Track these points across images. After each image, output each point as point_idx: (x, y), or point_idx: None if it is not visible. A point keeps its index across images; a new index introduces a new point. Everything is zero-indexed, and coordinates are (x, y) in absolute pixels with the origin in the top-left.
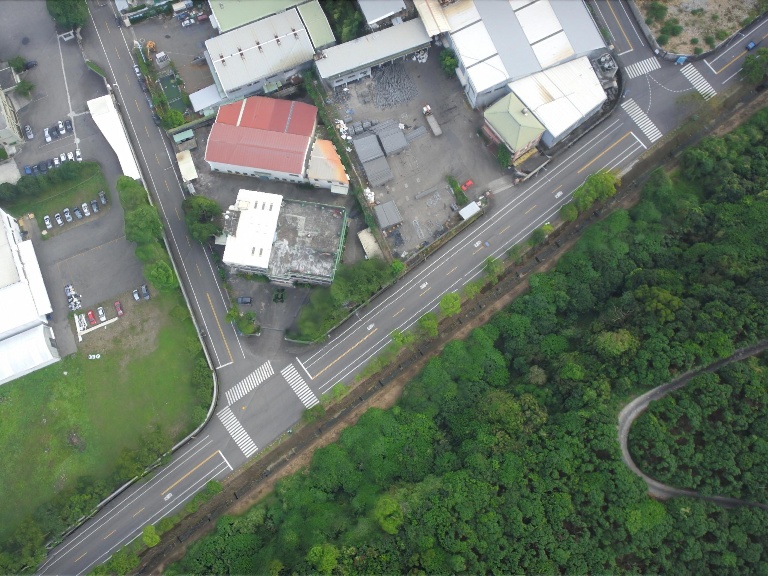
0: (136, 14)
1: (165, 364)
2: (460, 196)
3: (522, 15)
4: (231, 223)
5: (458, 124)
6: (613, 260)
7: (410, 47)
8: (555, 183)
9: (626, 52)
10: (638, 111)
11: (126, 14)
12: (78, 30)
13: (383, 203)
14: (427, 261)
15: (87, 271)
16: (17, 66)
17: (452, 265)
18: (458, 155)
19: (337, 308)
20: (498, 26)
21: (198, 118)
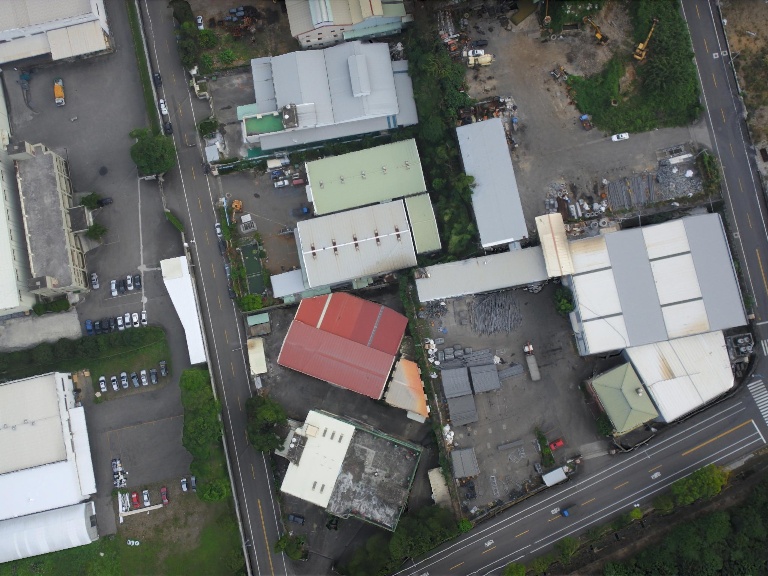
0: (226, 165)
1: (204, 566)
2: (547, 458)
3: (658, 268)
4: (296, 450)
5: (560, 370)
6: (702, 575)
7: (524, 283)
8: (654, 461)
9: (767, 322)
10: (765, 397)
11: (215, 165)
12: (161, 174)
13: (462, 449)
14: (497, 517)
15: (137, 447)
16: (91, 206)
17: (523, 528)
18: (553, 406)
19: (393, 560)
20: (629, 278)
21: (277, 301)
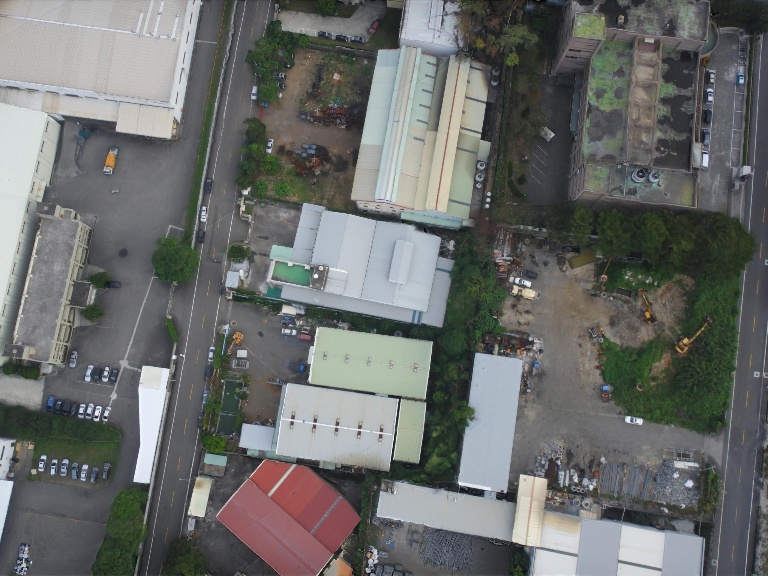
0: (242, 294)
1: None
2: None
3: (624, 573)
4: None
5: None
6: None
7: (486, 536)
8: None
9: None
10: None
11: (232, 291)
12: None
13: None
14: None
15: (51, 540)
16: (97, 286)
17: None
18: None
19: None
20: (591, 573)
21: (240, 448)
